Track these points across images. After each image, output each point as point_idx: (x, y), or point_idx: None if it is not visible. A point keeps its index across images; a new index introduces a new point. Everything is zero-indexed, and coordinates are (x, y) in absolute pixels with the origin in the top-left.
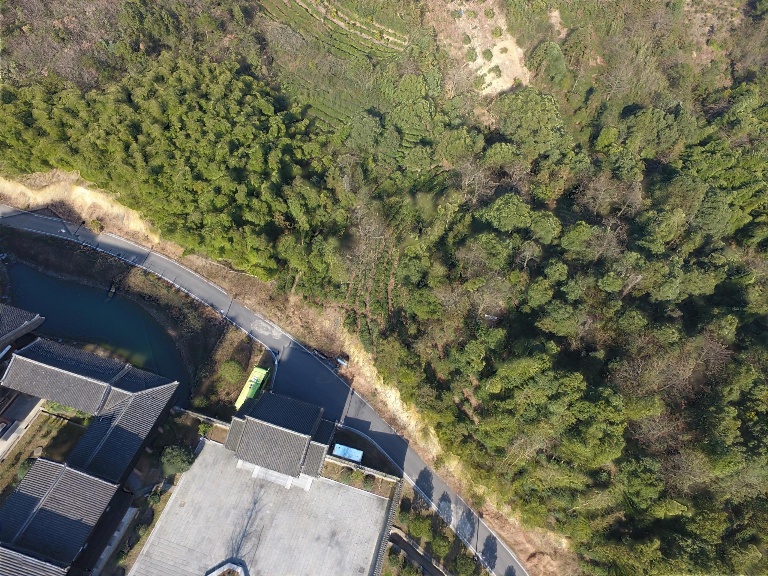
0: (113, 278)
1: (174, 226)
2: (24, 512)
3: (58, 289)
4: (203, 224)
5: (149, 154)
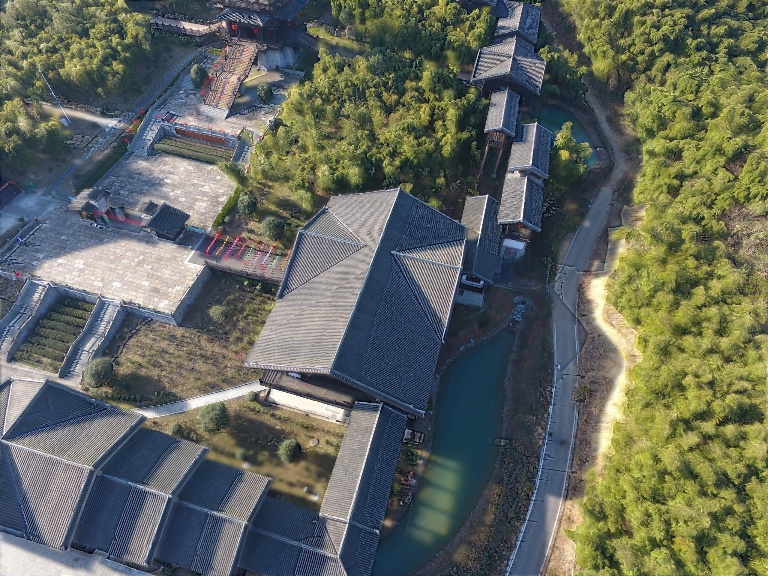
0: (517, 439)
1: (601, 516)
2: (211, 495)
3: (496, 379)
4: (620, 565)
5: (706, 449)
